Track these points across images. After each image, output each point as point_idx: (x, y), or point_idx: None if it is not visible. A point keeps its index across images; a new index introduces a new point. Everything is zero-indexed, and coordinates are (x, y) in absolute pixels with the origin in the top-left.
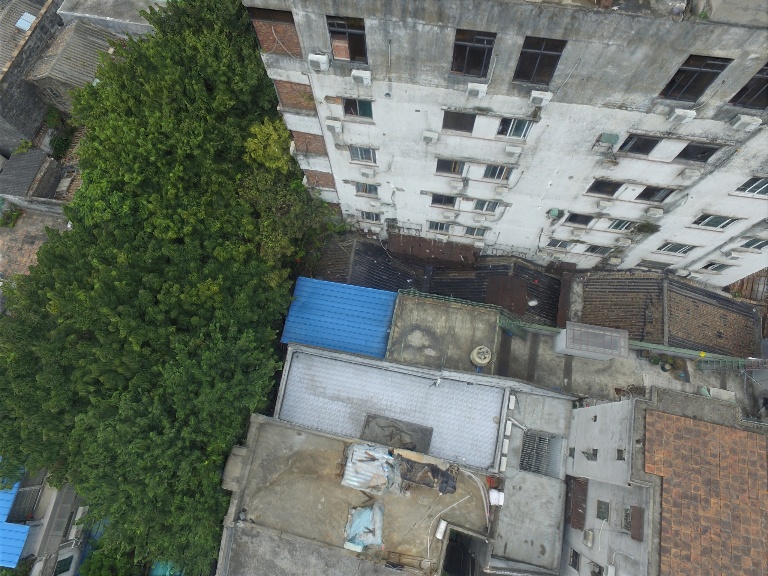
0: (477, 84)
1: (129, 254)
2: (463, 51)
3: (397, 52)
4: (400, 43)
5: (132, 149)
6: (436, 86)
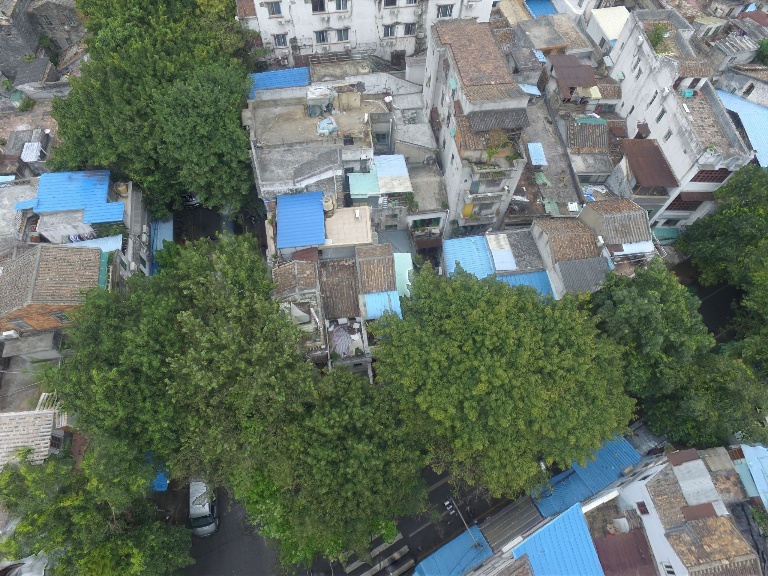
0: None
1: None
2: None
3: None
4: None
5: None
6: None
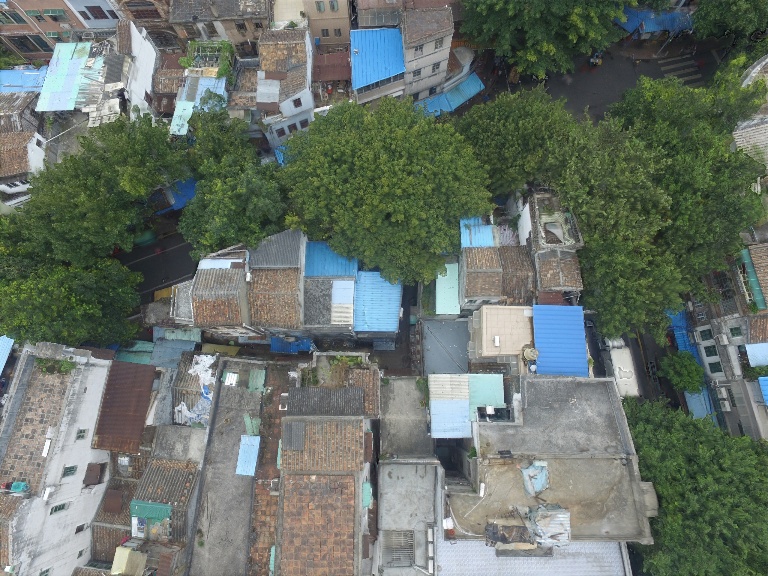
0: None
1: None
2: None
3: None
4: None
5: None
6: None
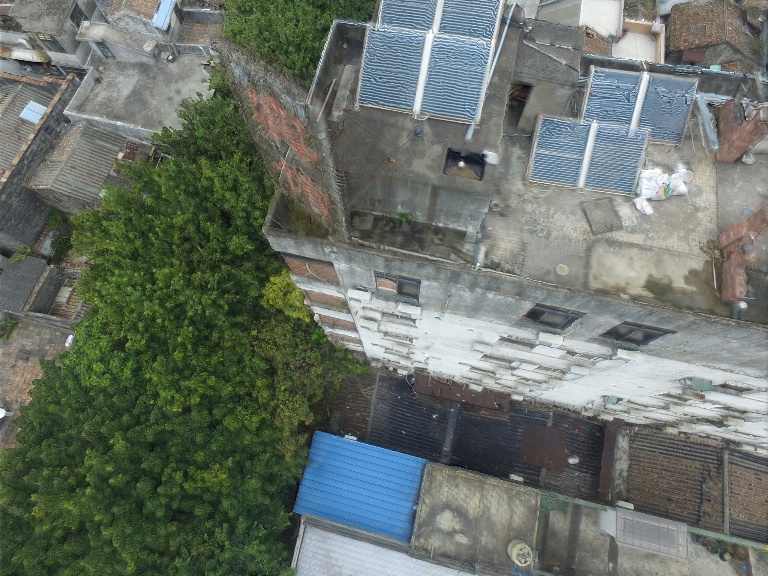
0: (550, 334)
1: (128, 431)
2: (539, 313)
3: (456, 301)
4: (462, 298)
5: (136, 307)
6: (498, 324)
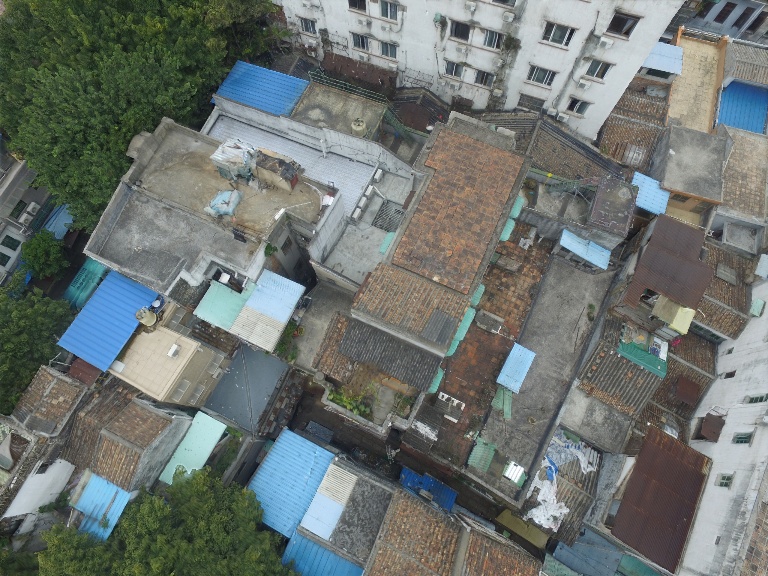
0: None
1: None
2: None
3: None
4: None
5: None
6: None
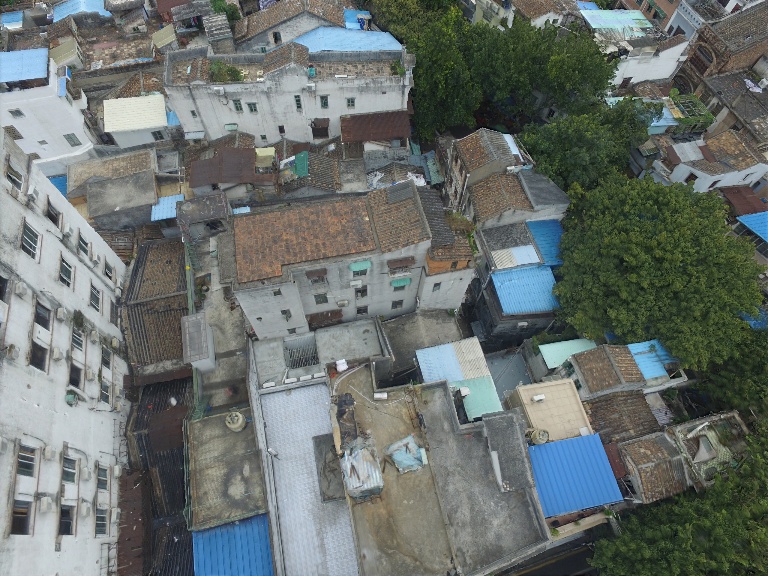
0: None
1: None
2: None
3: None
4: None
5: None
6: None
